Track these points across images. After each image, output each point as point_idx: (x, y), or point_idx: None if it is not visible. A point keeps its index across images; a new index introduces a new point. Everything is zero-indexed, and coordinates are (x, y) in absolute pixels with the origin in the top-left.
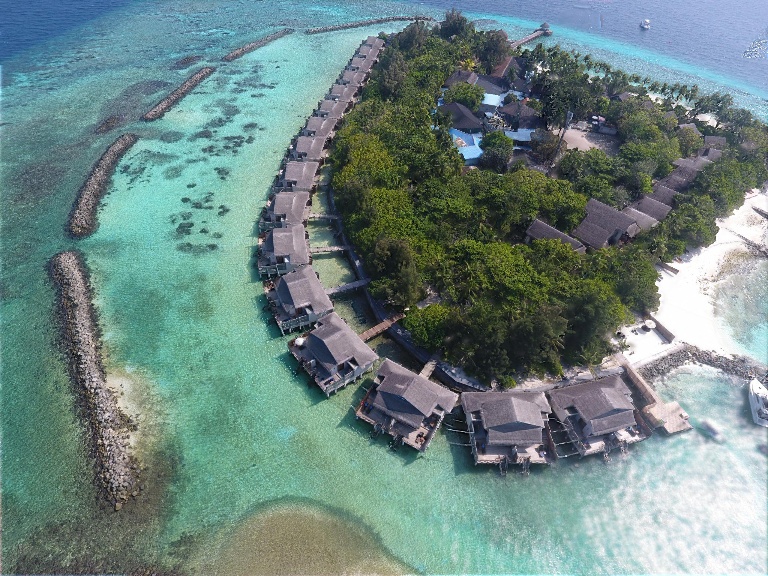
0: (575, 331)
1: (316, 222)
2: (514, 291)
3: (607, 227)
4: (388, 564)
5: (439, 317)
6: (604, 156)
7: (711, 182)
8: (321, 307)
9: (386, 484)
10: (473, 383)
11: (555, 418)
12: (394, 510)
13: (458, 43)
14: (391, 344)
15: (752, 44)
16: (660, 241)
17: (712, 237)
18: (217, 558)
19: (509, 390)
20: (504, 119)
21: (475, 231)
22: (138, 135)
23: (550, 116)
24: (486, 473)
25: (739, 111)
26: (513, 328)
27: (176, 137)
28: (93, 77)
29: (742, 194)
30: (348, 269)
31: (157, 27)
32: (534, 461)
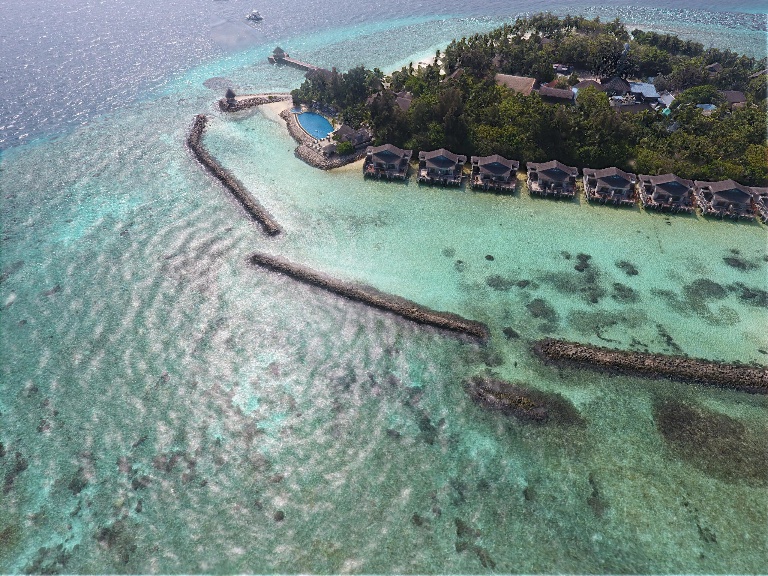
0: None
1: None
2: None
3: None
4: None
5: None
6: None
7: None
8: None
9: None
10: None
11: None
12: None
13: None
14: None
15: None
16: None
17: None
18: None
19: None
20: None
21: None
22: None
23: None
24: None
25: (555, 18)
26: None
27: None
28: None
29: None
30: None
31: None
32: None
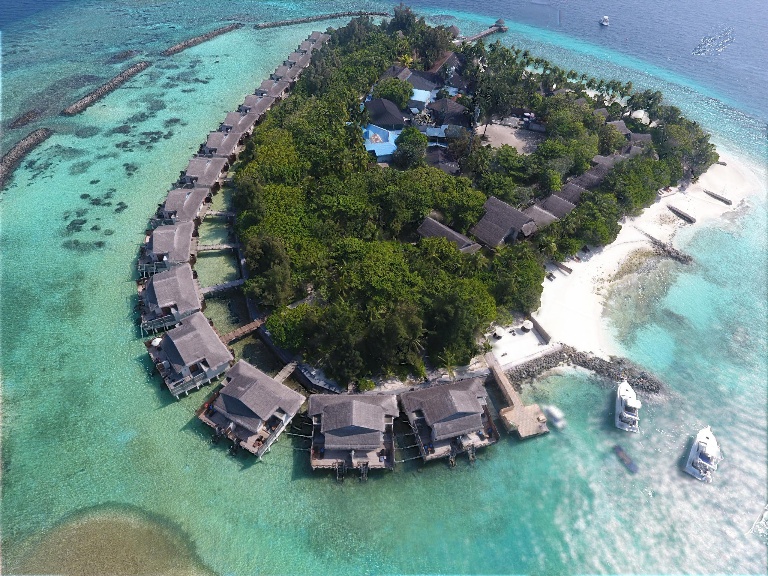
0: (437, 332)
1: (214, 219)
2: (382, 291)
3: (503, 225)
4: (195, 573)
5: (301, 317)
6: (515, 153)
7: (617, 180)
8: (187, 306)
9: (216, 490)
10: (330, 385)
11: (408, 421)
12: (217, 517)
13: (397, 38)
14: (259, 345)
15: (702, 41)
16: (548, 240)
17: (612, 236)
18: (16, 567)
19: (365, 392)
20: (431, 115)
21: (361, 229)
22: (53, 130)
23: (473, 112)
24: (324, 478)
25: (668, 108)
26: (369, 329)
27: (92, 132)
28: (23, 71)
29: (653, 192)
30: (235, 267)
31: (103, 21)
32: (372, 466)
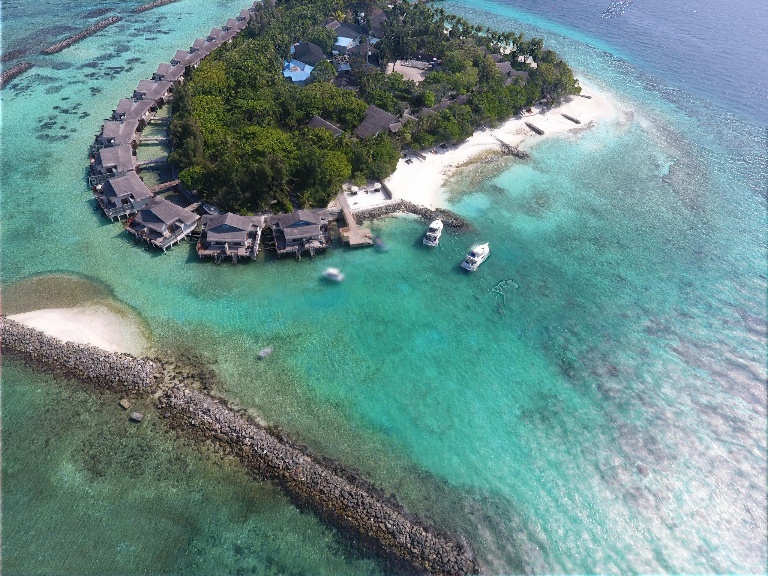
0: (300, 179)
1: (157, 124)
2: (264, 154)
3: (377, 125)
4: (111, 301)
5: (204, 170)
6: (401, 78)
7: None
8: (124, 167)
9: (132, 266)
10: None
11: None
12: (131, 278)
13: None
14: (177, 196)
15: (609, 6)
16: (403, 130)
17: (463, 135)
18: None
19: None
20: None
21: (262, 122)
22: (34, 64)
23: None
24: (207, 263)
25: (546, 52)
26: (248, 173)
27: (66, 66)
28: (10, 22)
29: (510, 109)
30: (168, 153)
31: None
32: (239, 254)
